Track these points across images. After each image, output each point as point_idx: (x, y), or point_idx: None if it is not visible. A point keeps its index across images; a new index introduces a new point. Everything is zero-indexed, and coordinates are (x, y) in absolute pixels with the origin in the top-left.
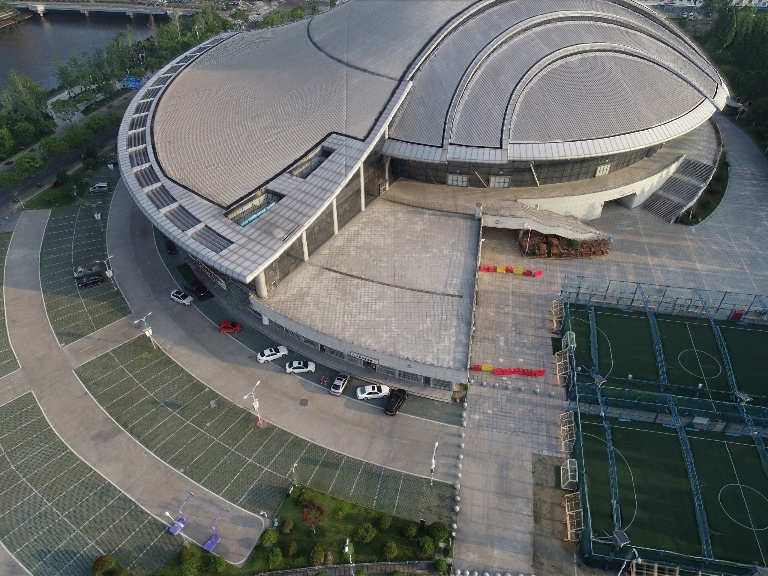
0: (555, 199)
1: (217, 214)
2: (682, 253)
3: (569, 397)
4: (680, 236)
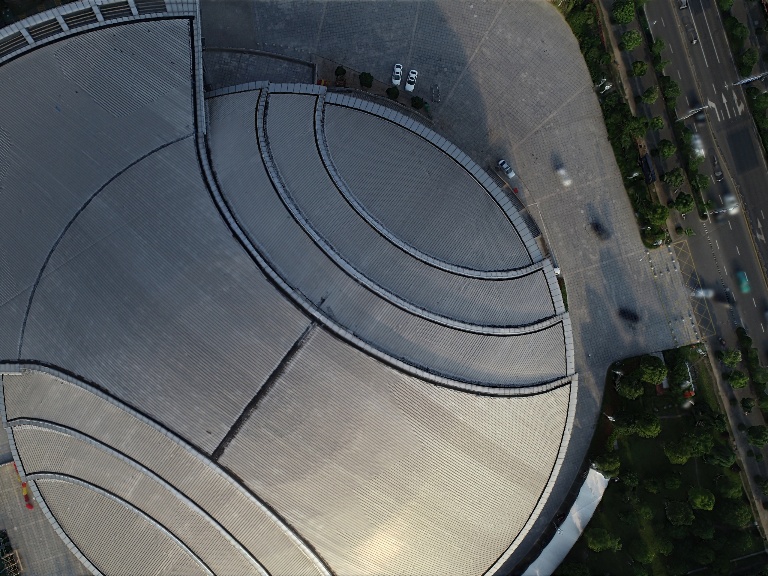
0: None
1: None
2: None
3: None
4: None
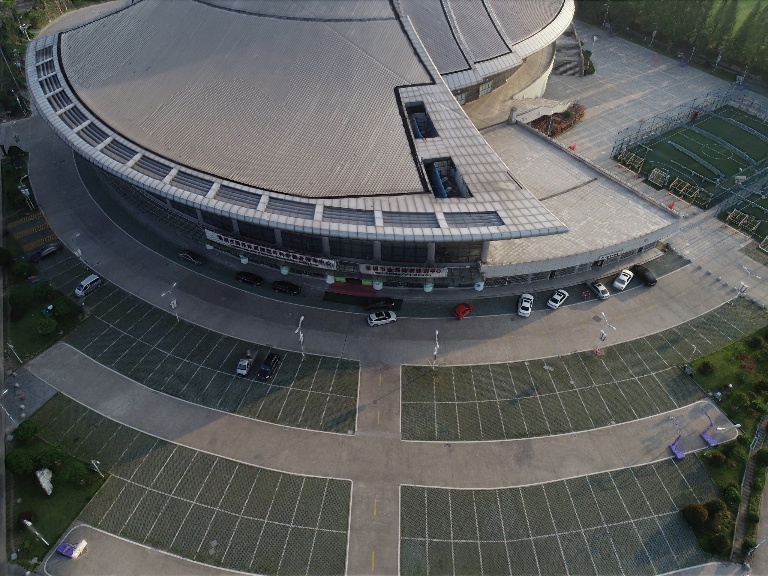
0: (532, 86)
1: (432, 200)
2: (615, 93)
3: (703, 209)
4: (599, 83)
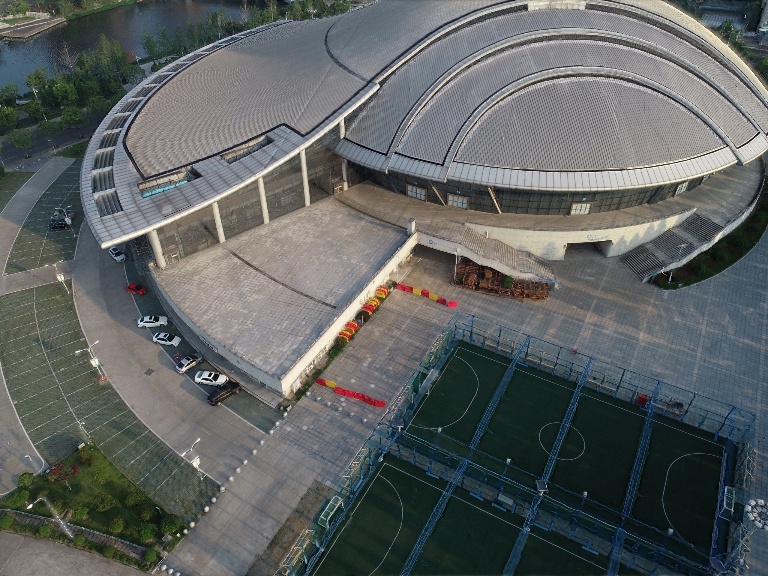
0: (506, 230)
1: (133, 183)
2: (632, 317)
3: (392, 436)
4: (644, 298)
